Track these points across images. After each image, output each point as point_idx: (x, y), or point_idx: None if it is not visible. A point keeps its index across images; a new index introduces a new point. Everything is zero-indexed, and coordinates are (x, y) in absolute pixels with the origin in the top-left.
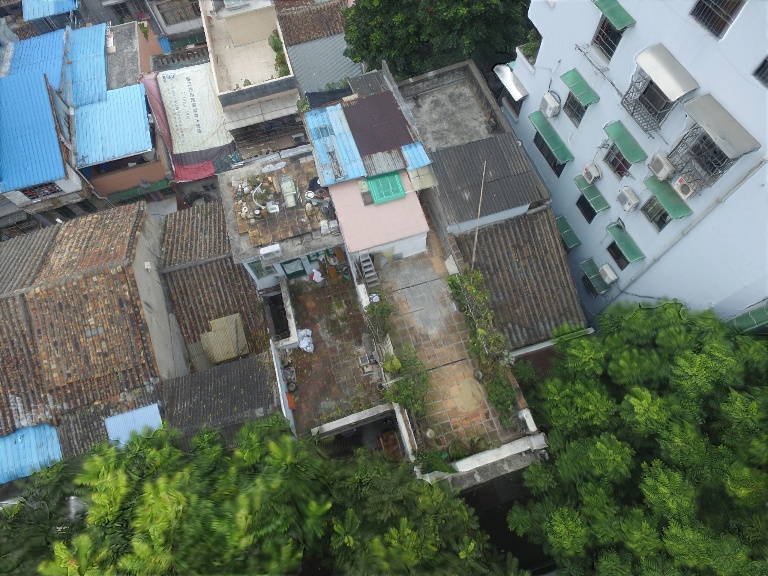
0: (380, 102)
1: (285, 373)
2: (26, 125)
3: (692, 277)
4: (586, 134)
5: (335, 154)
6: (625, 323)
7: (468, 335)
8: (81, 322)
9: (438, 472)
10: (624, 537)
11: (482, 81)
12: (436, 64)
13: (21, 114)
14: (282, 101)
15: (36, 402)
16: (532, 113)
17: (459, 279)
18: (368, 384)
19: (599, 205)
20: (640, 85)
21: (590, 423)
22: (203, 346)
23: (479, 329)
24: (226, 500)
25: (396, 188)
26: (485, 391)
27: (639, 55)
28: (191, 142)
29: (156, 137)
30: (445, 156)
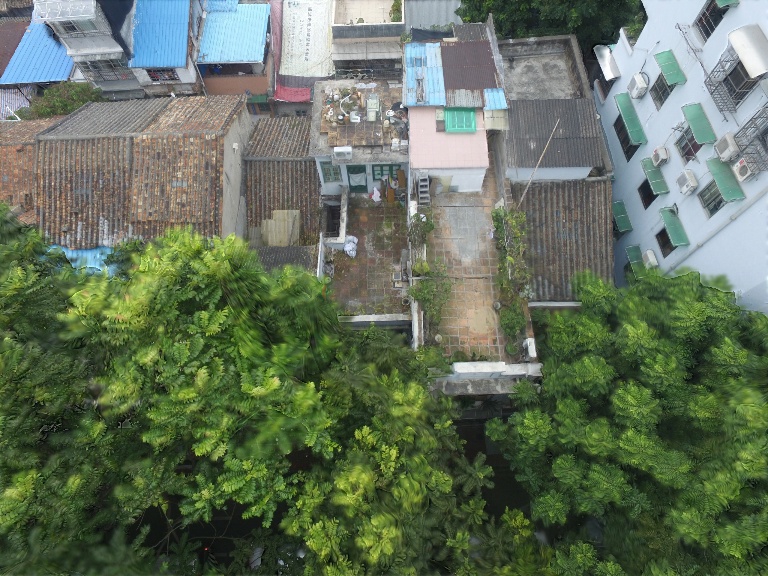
0: (476, 48)
1: (325, 267)
2: (166, 15)
3: (729, 264)
4: (665, 117)
5: (423, 82)
6: (647, 277)
7: (498, 271)
8: (171, 173)
9: (436, 369)
10: (586, 444)
11: (579, 55)
12: (540, 36)
13: (164, 5)
14: (387, 45)
15: (119, 229)
16: (619, 94)
17: (503, 212)
18: (395, 297)
19: (659, 188)
20: (728, 67)
21: (585, 348)
22: (262, 230)
23: (509, 257)
24: (259, 290)
25: (469, 123)
26: (499, 321)
27: (733, 32)
28: (297, 67)
29: (268, 55)
30: (522, 106)
